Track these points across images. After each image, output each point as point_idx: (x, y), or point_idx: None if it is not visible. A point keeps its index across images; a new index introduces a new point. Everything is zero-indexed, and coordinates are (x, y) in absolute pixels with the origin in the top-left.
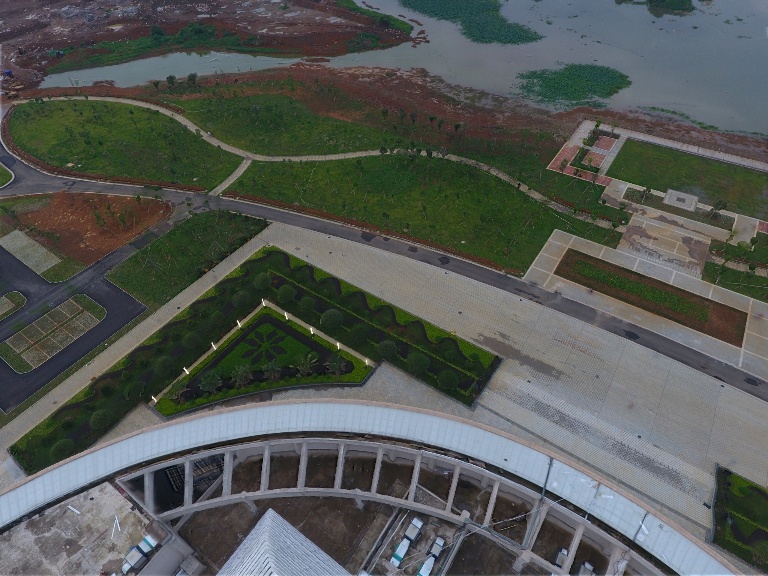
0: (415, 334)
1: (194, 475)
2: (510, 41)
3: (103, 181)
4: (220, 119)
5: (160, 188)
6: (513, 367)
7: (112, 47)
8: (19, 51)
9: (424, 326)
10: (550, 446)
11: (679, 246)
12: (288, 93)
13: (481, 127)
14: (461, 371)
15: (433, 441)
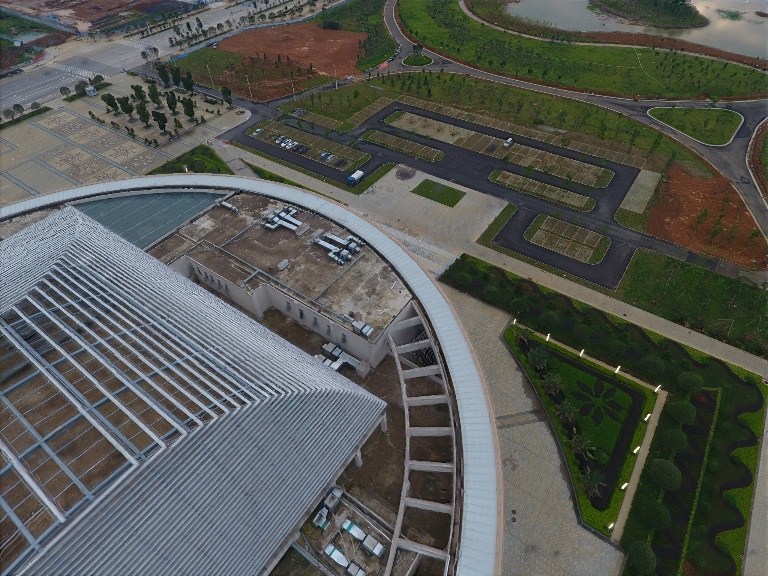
0: None
1: (422, 349)
2: None
3: (767, 201)
4: None
5: None
6: None
7: None
8: None
9: None
10: None
11: None
12: None
13: None
14: None
15: (461, 571)
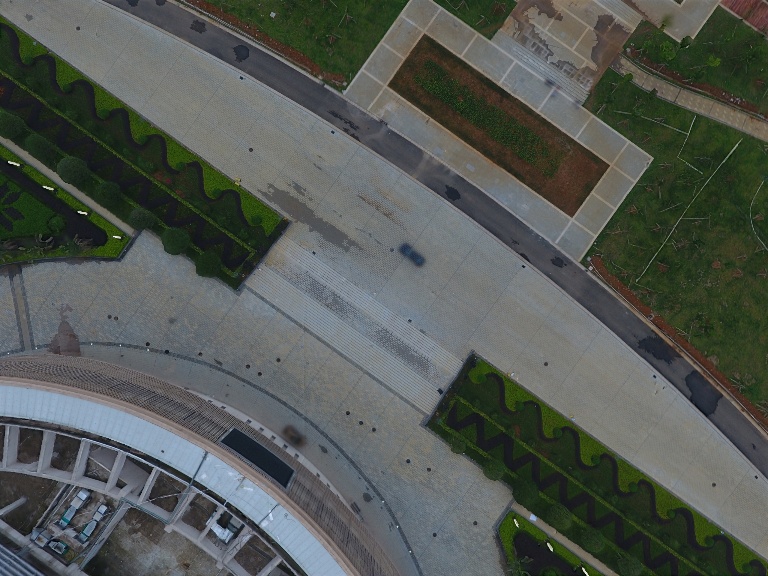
0: (189, 185)
1: None
2: None
3: None
4: None
5: None
6: (300, 234)
7: None
8: None
9: (202, 171)
10: (309, 336)
11: (586, 35)
12: None
13: None
14: (236, 241)
15: (94, 430)
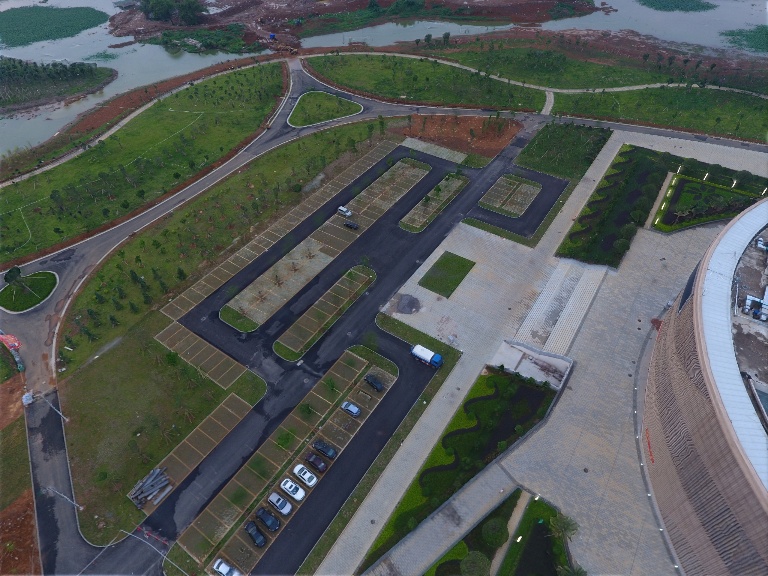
0: None
1: None
2: (691, 9)
3: (442, 107)
4: (497, 65)
5: (496, 110)
6: None
7: (338, 17)
8: (261, 21)
9: None
10: None
11: None
12: (537, 47)
13: (722, 69)
14: None
15: None
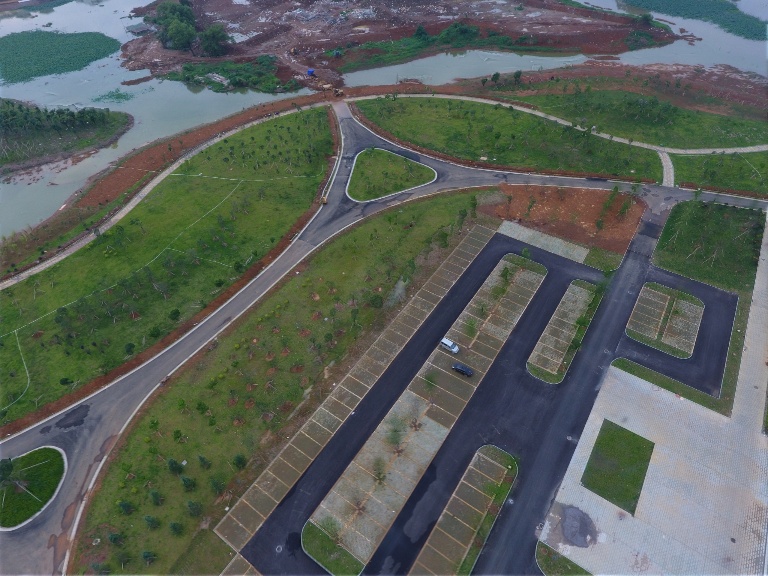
0: None
1: None
2: None
3: (535, 174)
4: (587, 114)
5: (605, 180)
6: None
7: (382, 47)
8: (294, 52)
9: None
10: None
11: None
12: (627, 89)
13: None
14: None
15: None
